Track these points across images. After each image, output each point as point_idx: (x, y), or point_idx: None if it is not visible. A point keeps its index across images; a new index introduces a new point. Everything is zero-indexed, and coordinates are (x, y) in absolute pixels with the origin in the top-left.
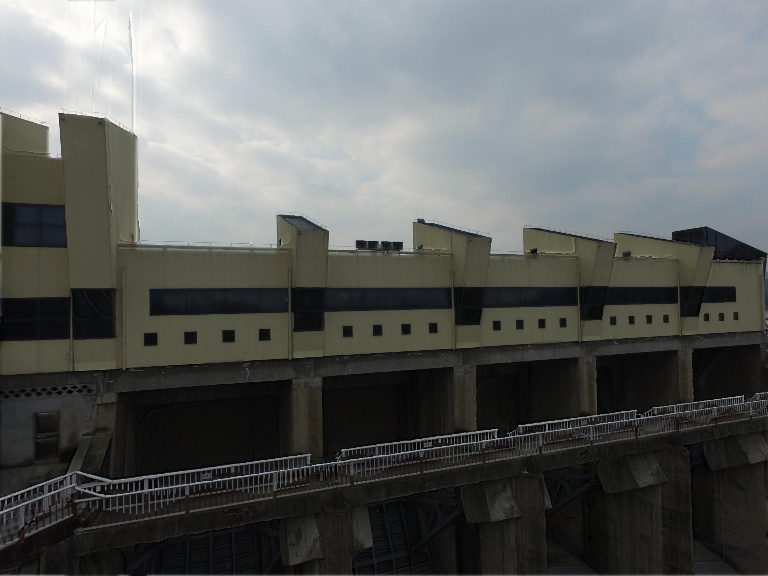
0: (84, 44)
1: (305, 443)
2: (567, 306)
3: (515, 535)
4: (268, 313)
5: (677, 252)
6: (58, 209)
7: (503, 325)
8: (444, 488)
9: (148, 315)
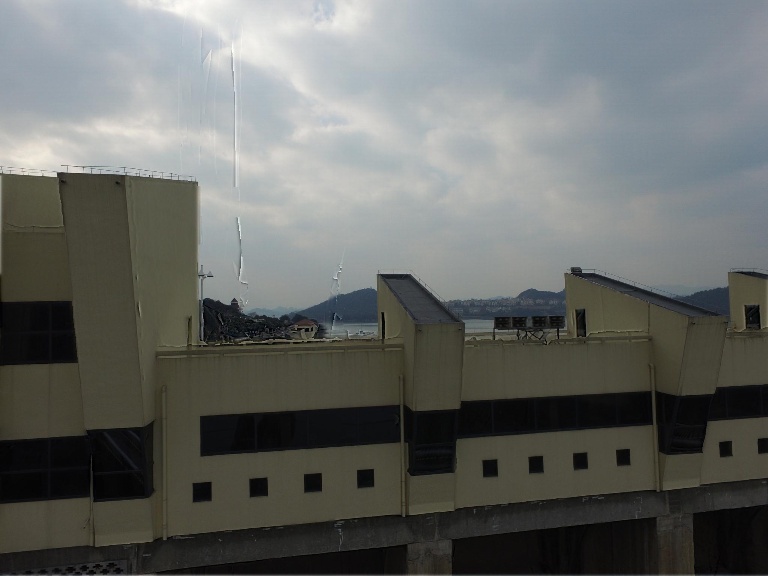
0: (193, 76)
1: None
2: None
3: None
4: (370, 445)
5: None
6: None
7: (736, 447)
8: None
9: (198, 455)
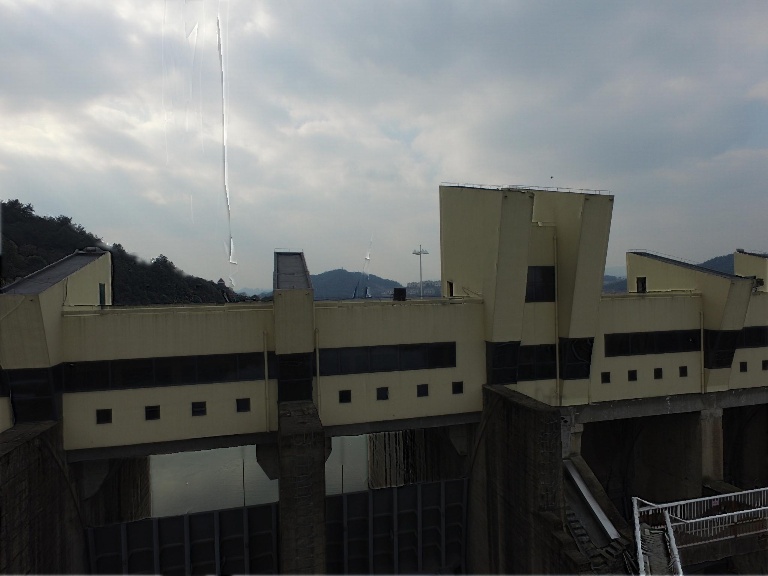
0: (177, 50)
1: (711, 467)
2: None
3: None
4: (685, 352)
5: None
6: (544, 269)
7: None
8: None
9: (603, 357)
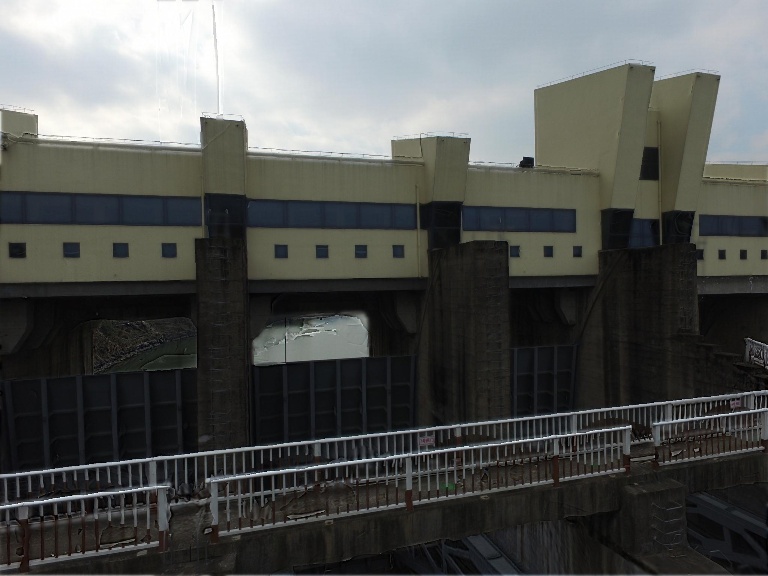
0: (171, 37)
1: None
2: None
3: None
4: (766, 237)
5: None
6: (649, 150)
7: None
8: None
9: (698, 235)
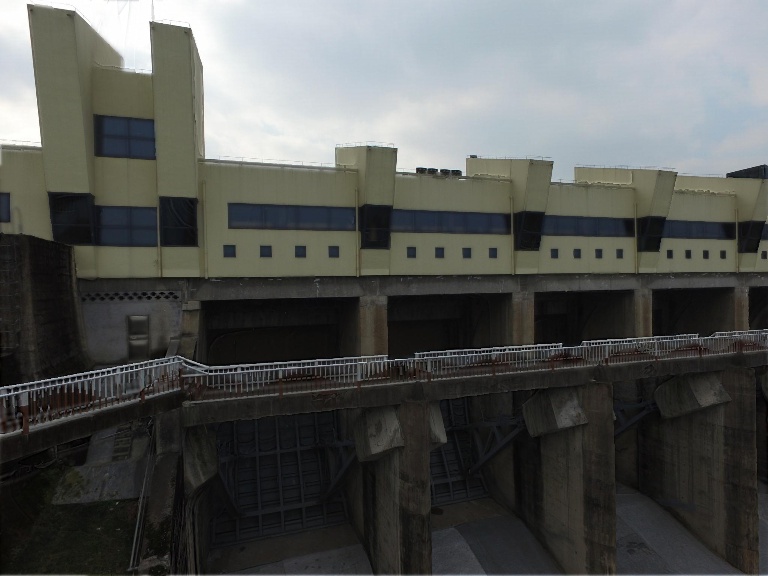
0: (109, 28)
1: None
2: (624, 237)
3: (581, 442)
4: (337, 231)
5: (736, 187)
6: (143, 123)
7: (561, 253)
8: (501, 413)
9: (227, 228)
